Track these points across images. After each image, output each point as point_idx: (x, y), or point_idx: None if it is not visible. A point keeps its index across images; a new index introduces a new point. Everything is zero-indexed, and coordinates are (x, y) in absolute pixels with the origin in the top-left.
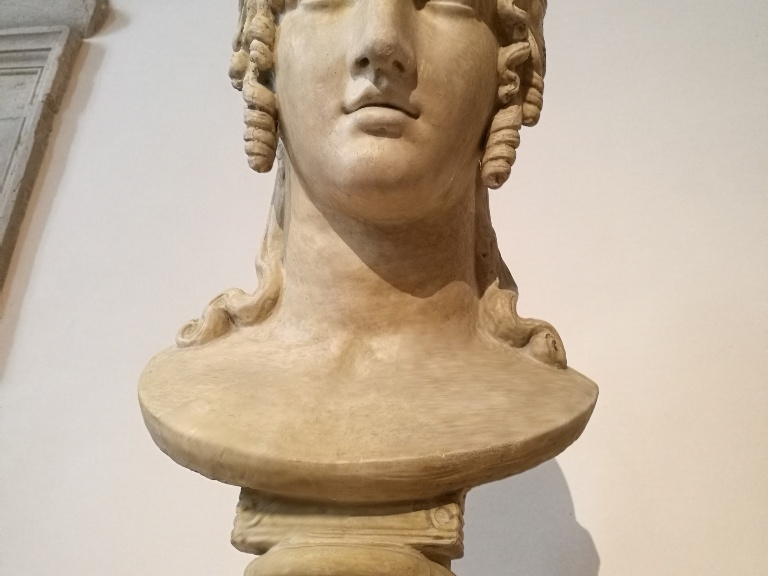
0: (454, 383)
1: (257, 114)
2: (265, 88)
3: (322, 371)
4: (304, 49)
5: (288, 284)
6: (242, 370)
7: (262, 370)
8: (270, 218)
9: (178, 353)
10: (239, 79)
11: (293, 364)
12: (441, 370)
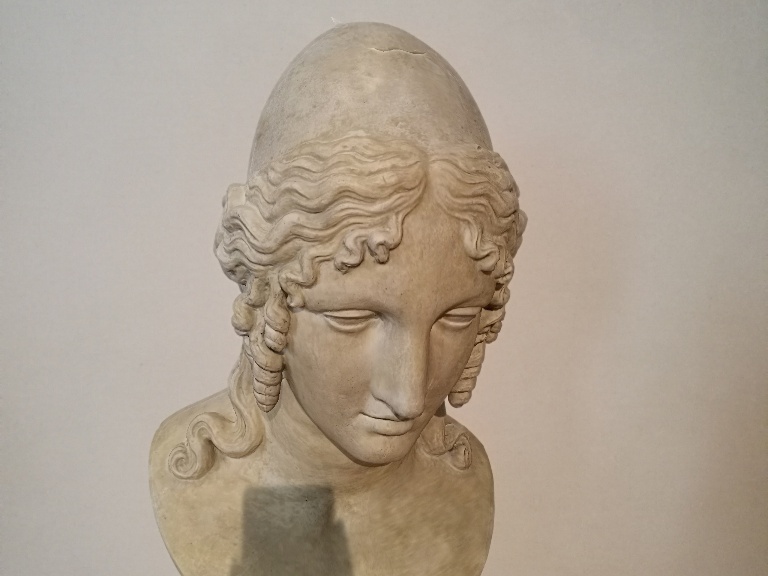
0: (411, 532)
1: (269, 378)
2: (276, 354)
3: (317, 531)
4: (329, 365)
5: (274, 443)
6: (253, 532)
7: (270, 534)
8: (245, 367)
9: (178, 487)
10: (244, 331)
11: (292, 523)
12: (400, 514)
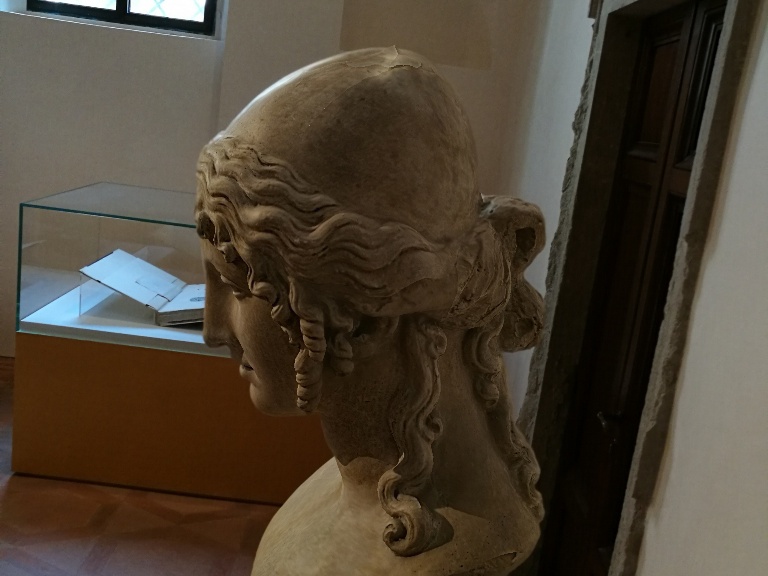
0: (328, 540)
1: None
2: None
3: None
4: None
5: None
6: None
7: None
8: None
9: None
10: None
11: None
12: (340, 524)
